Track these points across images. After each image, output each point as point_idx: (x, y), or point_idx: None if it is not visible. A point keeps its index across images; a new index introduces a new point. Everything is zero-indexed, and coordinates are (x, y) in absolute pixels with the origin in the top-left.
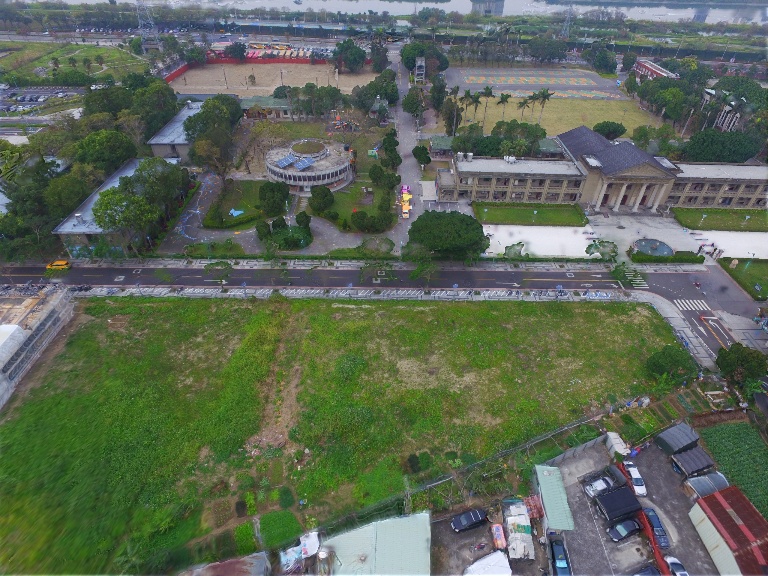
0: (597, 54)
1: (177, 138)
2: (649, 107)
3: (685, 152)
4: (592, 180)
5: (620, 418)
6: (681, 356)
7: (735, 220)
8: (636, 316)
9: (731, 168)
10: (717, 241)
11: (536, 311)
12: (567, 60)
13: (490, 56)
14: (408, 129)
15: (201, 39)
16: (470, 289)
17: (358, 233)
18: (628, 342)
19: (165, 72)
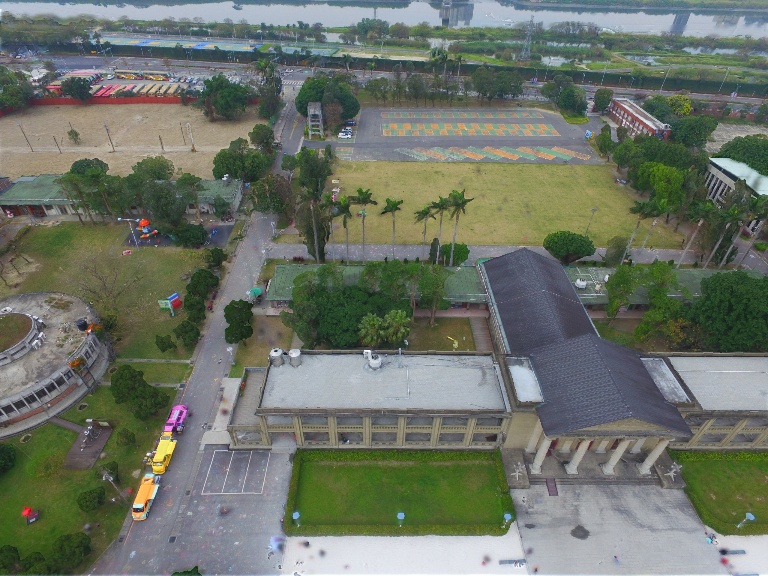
0: (561, 90)
1: None
2: None
3: (696, 322)
4: (523, 420)
5: None
6: None
7: None
8: None
9: None
10: None
11: None
12: (524, 95)
13: (421, 93)
14: (260, 235)
15: None
16: None
17: None
18: None
19: None
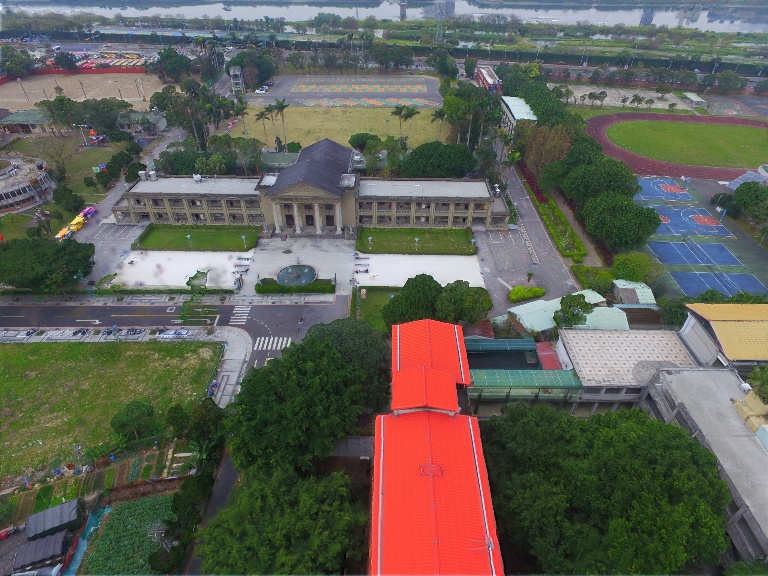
0: (438, 60)
1: None
2: None
3: (400, 167)
4: (267, 200)
5: (38, 490)
6: (131, 415)
7: (422, 241)
8: (191, 359)
9: (435, 184)
10: (379, 266)
11: (77, 355)
12: (418, 66)
13: (330, 63)
14: None
15: None
16: (38, 328)
17: None
18: (145, 392)
19: None
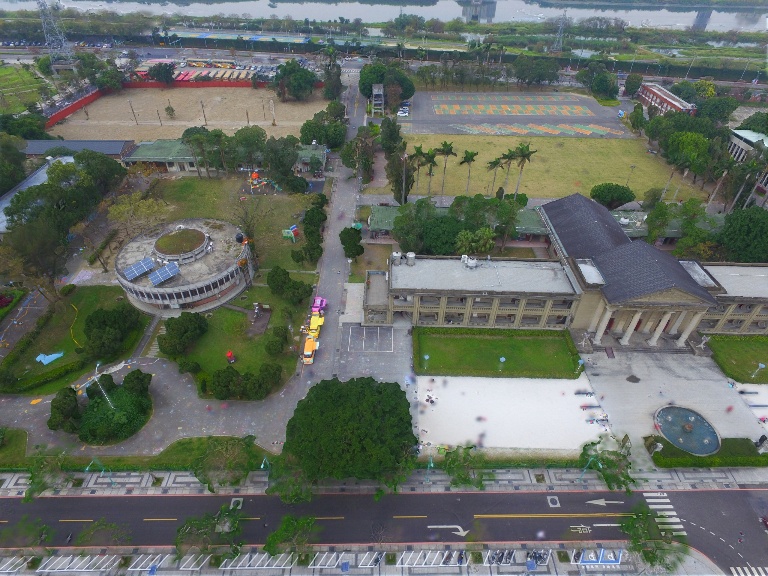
0: (595, 76)
1: (4, 222)
2: (660, 150)
3: (721, 243)
4: (589, 301)
5: None
6: None
7: None
8: None
9: None
10: None
11: None
12: (559, 81)
13: (467, 78)
14: (348, 188)
15: (128, 56)
16: (380, 546)
17: (226, 399)
18: None
19: (67, 102)
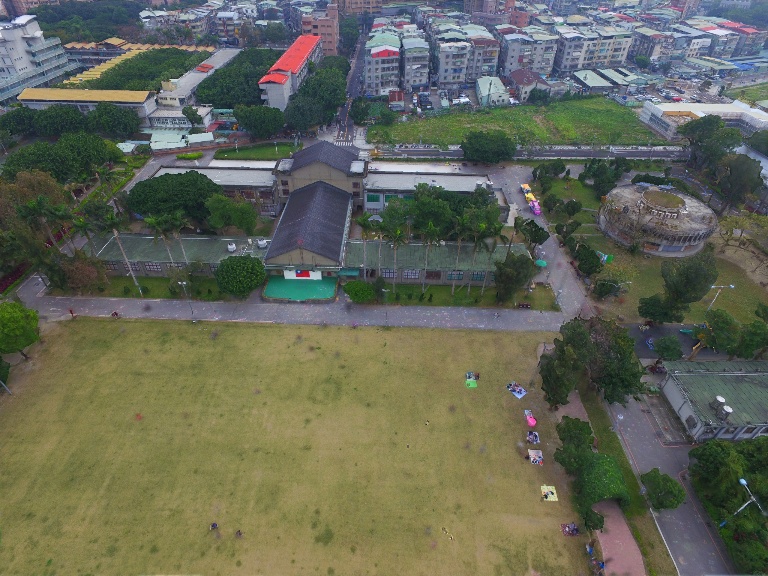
0: None
1: None
2: None
3: None
4: None
5: None
6: (385, 110)
7: None
8: None
9: None
10: None
11: None
12: None
13: None
14: None
15: None
16: None
17: None
18: None
19: None
